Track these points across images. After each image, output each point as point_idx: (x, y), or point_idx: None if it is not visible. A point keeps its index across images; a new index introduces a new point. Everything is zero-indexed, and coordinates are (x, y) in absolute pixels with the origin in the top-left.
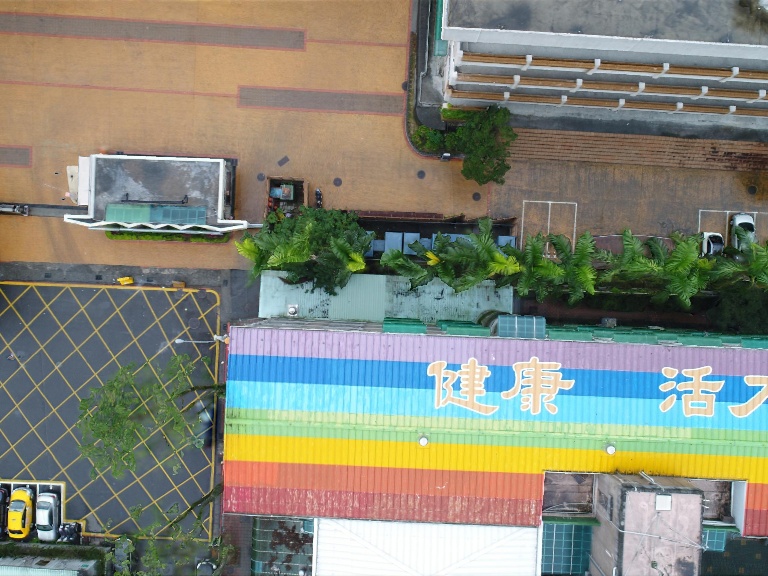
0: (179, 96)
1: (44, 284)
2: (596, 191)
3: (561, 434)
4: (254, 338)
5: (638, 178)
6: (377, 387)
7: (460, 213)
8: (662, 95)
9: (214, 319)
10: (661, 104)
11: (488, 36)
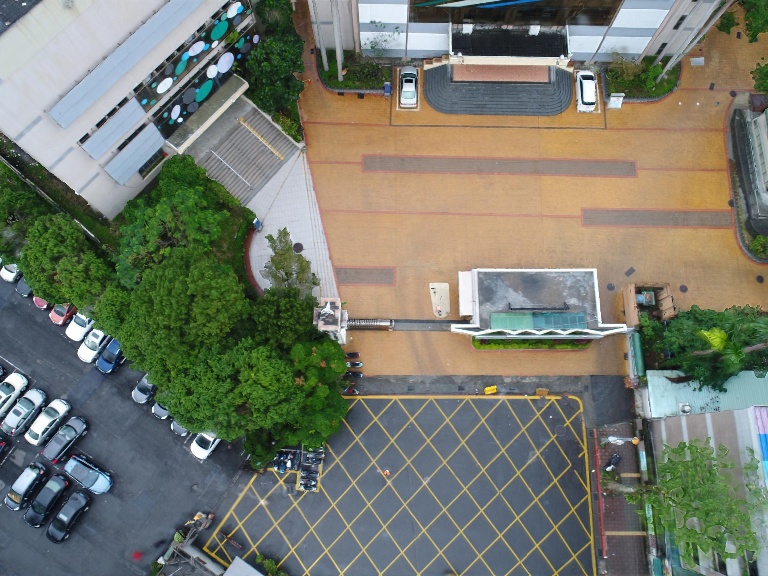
0: (529, 218)
1: (408, 397)
2: None
3: None
4: None
5: None
6: None
7: None
8: None
9: (579, 426)
10: None
11: None
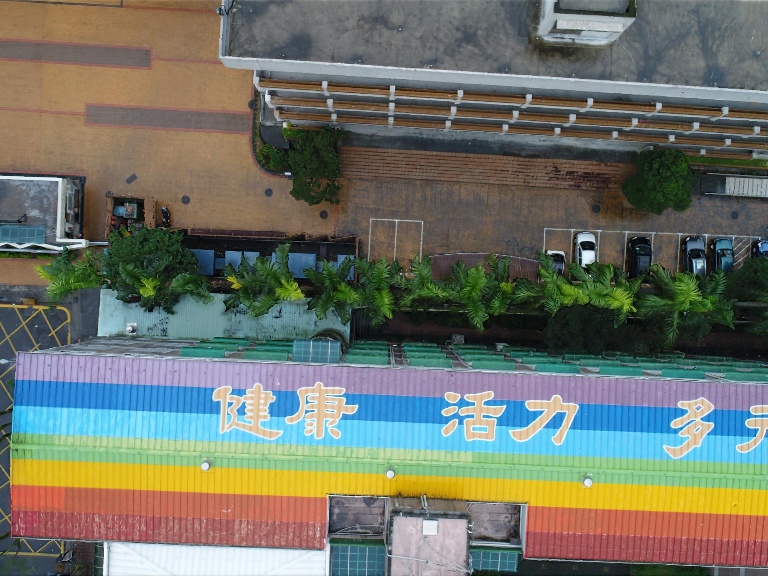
0: (26, 114)
1: None
2: (442, 209)
3: (344, 458)
4: (41, 364)
5: (484, 196)
6: (162, 412)
7: (307, 231)
8: (480, 118)
9: (65, 336)
10: (487, 126)
11: (268, 65)
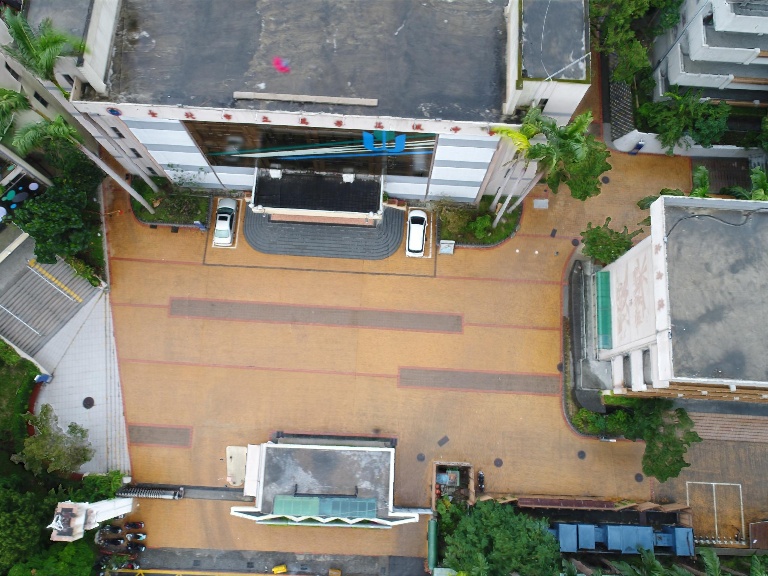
0: (341, 376)
1: (192, 573)
2: (758, 472)
3: None
4: None
5: None
6: None
7: (624, 495)
8: None
9: None
10: None
11: (709, 382)
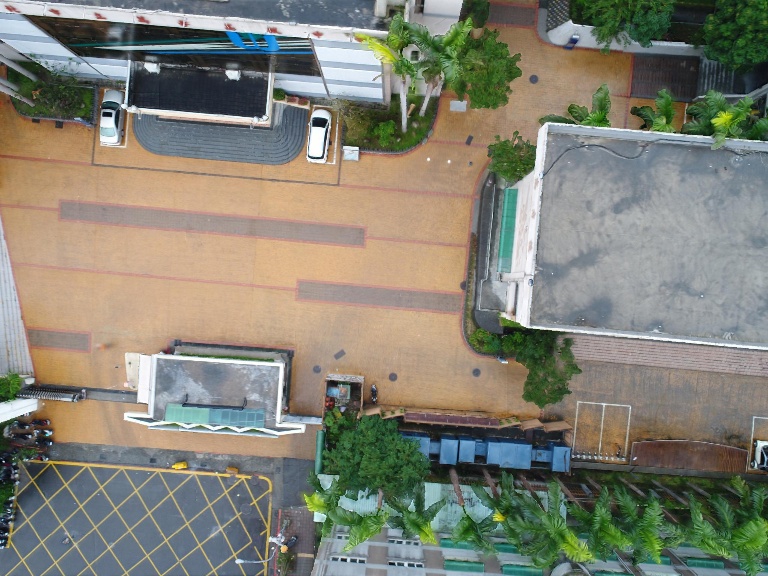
0: (238, 288)
1: (99, 465)
2: (651, 395)
3: None
4: None
5: (693, 383)
6: None
7: (514, 412)
8: None
9: (266, 505)
10: None
11: None
